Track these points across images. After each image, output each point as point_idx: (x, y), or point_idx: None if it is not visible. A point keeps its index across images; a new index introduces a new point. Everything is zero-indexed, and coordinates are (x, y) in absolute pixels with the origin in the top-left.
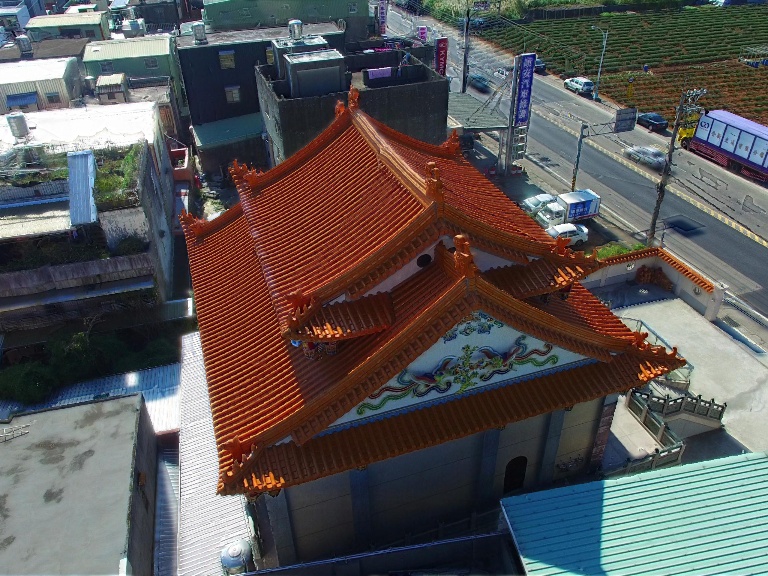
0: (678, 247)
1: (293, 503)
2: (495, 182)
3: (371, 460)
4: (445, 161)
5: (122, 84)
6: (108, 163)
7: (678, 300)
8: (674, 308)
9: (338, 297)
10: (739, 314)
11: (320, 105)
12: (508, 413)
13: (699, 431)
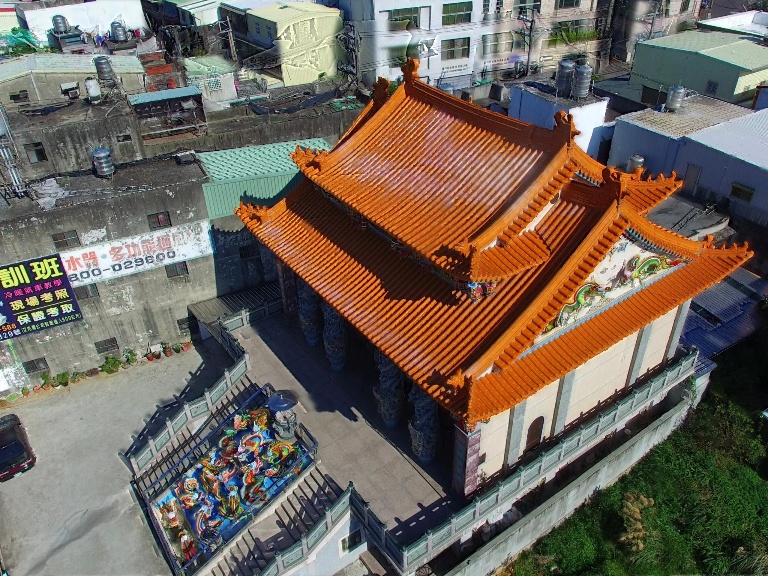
0: None
1: None
2: None
3: None
4: None
5: None
6: None
7: None
8: None
9: None
10: None
11: None
12: None
13: None
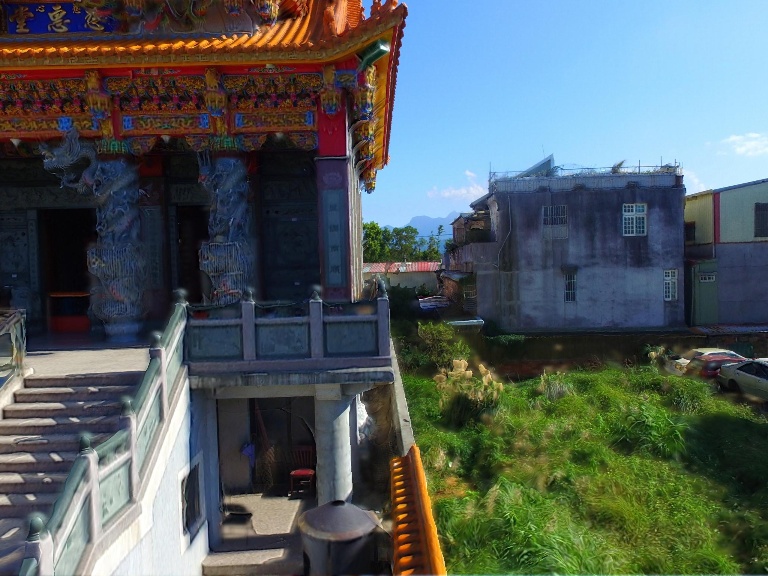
0: None
1: None
2: None
3: None
4: None
5: None
6: None
7: None
8: None
9: None
10: None
11: None
12: None
13: None
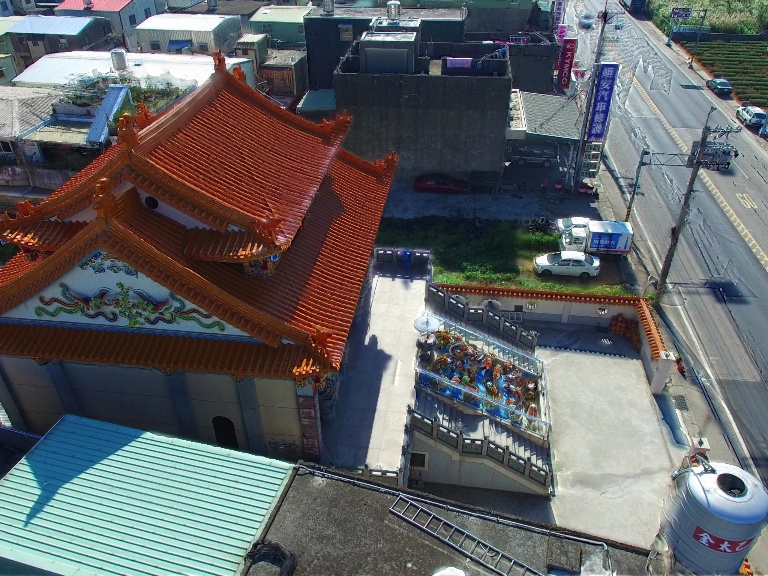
0: (698, 310)
1: (11, 377)
2: (556, 196)
3: (25, 353)
4: (311, 137)
5: (256, 43)
6: (158, 100)
7: (637, 361)
8: (623, 367)
9: (56, 216)
10: (699, 398)
11: (374, 83)
12: (154, 357)
13: (517, 489)
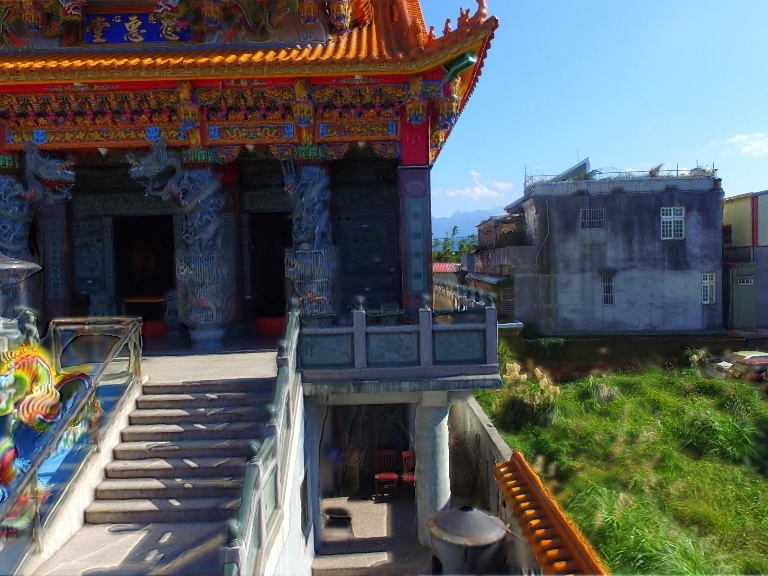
0: None
1: None
2: None
3: None
4: None
5: None
6: None
7: None
8: None
9: None
10: None
11: None
12: None
13: None
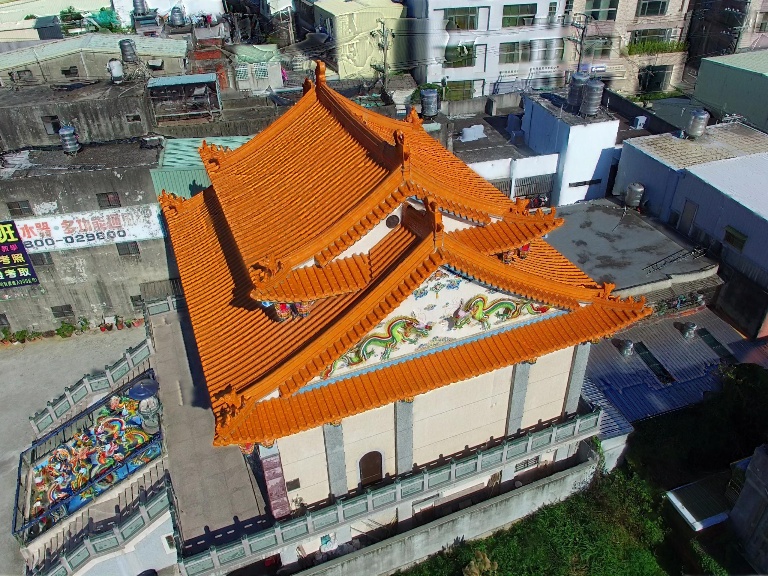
0: None
1: None
2: None
3: None
4: None
5: None
6: None
7: None
8: None
9: None
10: None
11: None
12: None
13: None
